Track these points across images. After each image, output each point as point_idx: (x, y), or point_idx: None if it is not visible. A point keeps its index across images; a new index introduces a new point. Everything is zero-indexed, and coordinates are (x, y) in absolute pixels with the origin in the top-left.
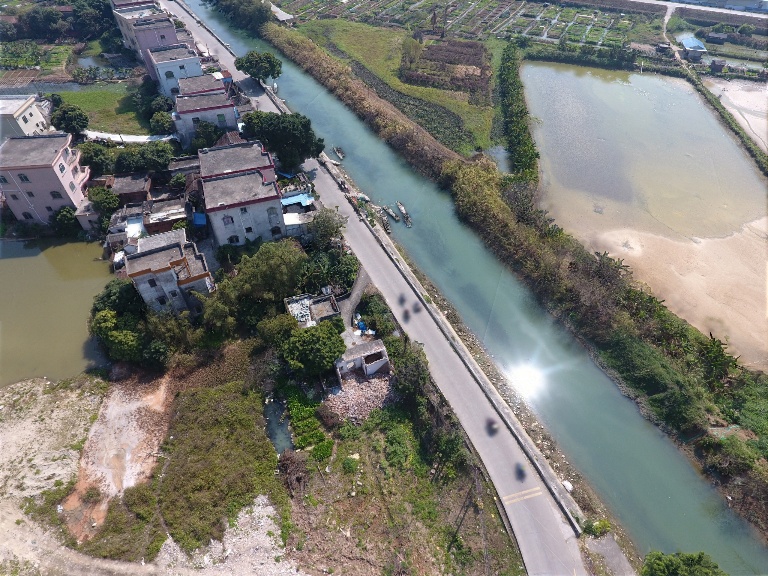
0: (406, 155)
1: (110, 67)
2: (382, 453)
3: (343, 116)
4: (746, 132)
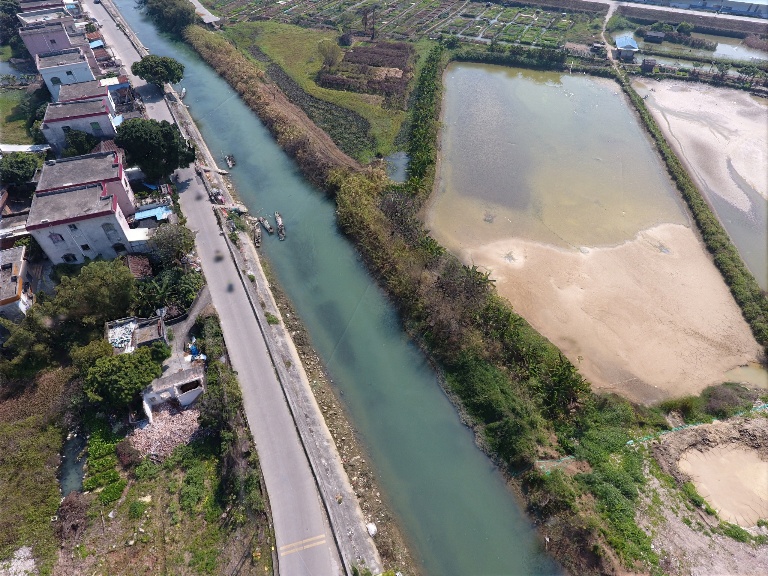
0: (300, 162)
1: (18, 73)
2: (177, 494)
3: (246, 122)
4: (664, 134)
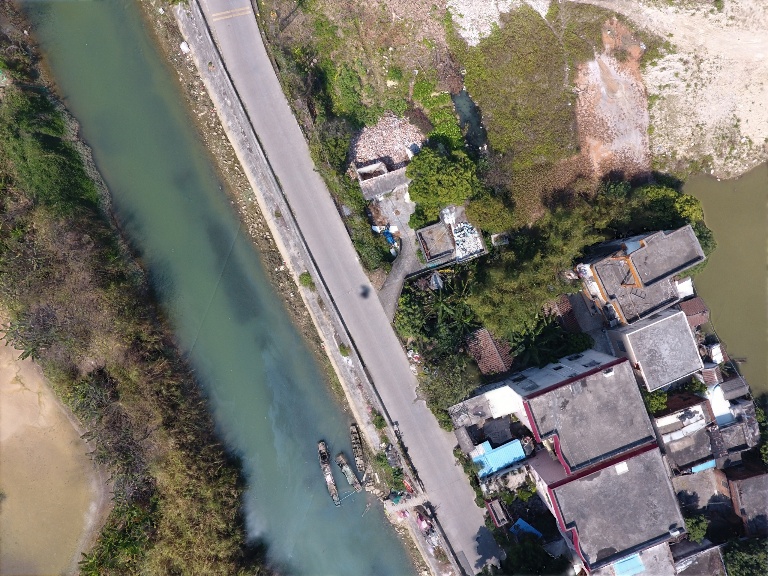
0: None
1: None
2: (364, 85)
3: None
4: None
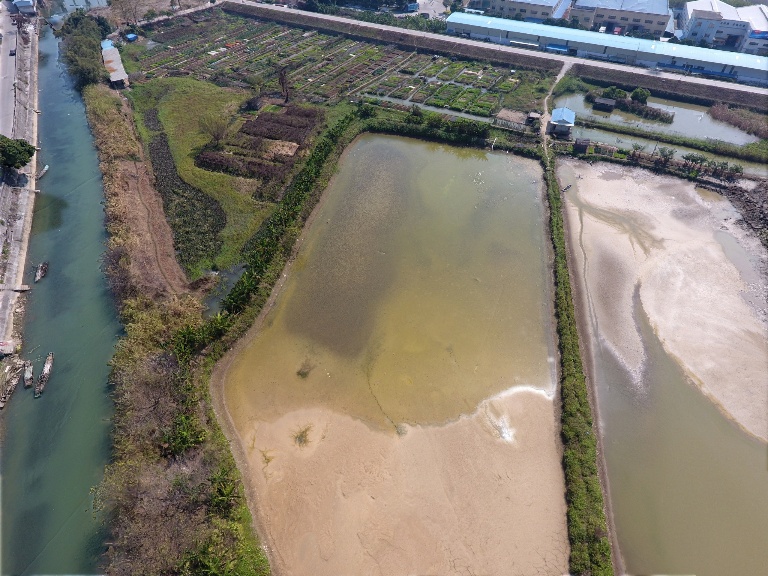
0: None
1: None
2: None
3: (90, 214)
4: (571, 243)
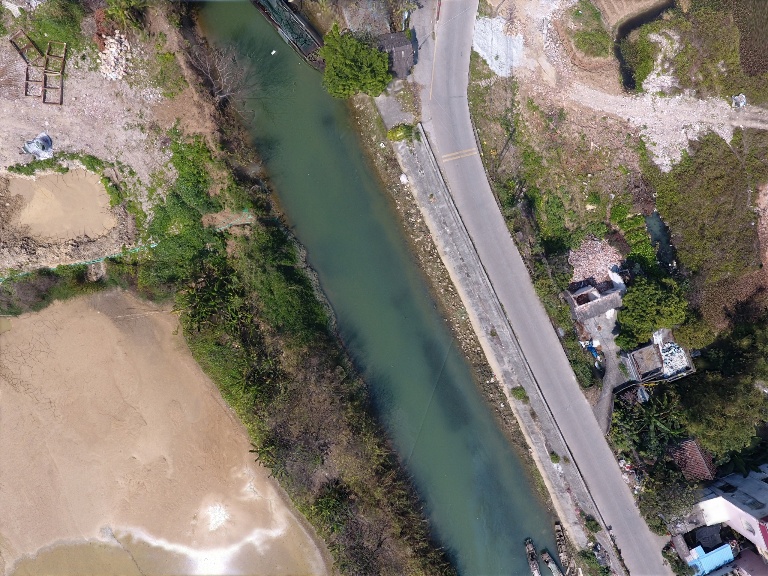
0: None
1: None
2: (567, 209)
3: None
4: None
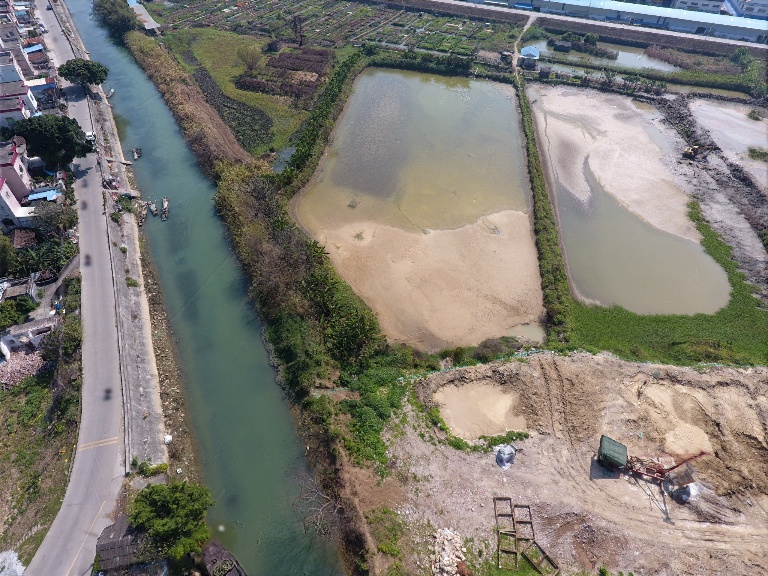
0: None
1: None
2: (17, 413)
3: (161, 119)
4: (538, 134)
